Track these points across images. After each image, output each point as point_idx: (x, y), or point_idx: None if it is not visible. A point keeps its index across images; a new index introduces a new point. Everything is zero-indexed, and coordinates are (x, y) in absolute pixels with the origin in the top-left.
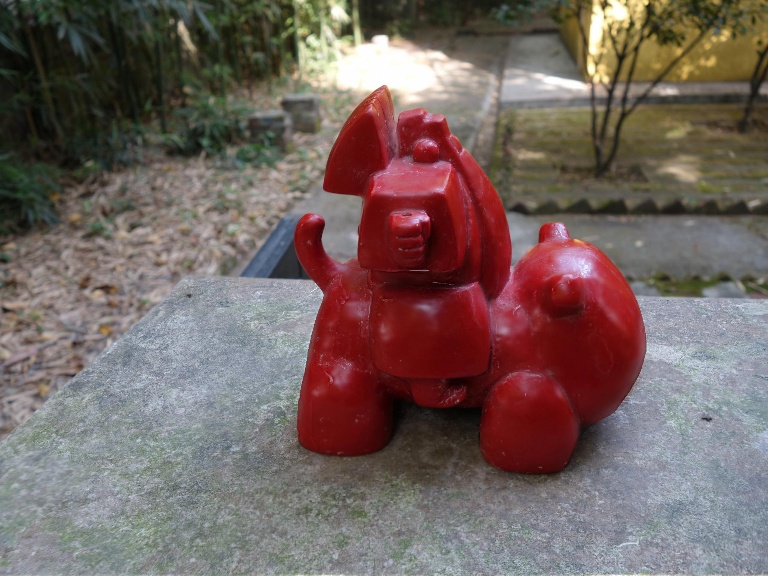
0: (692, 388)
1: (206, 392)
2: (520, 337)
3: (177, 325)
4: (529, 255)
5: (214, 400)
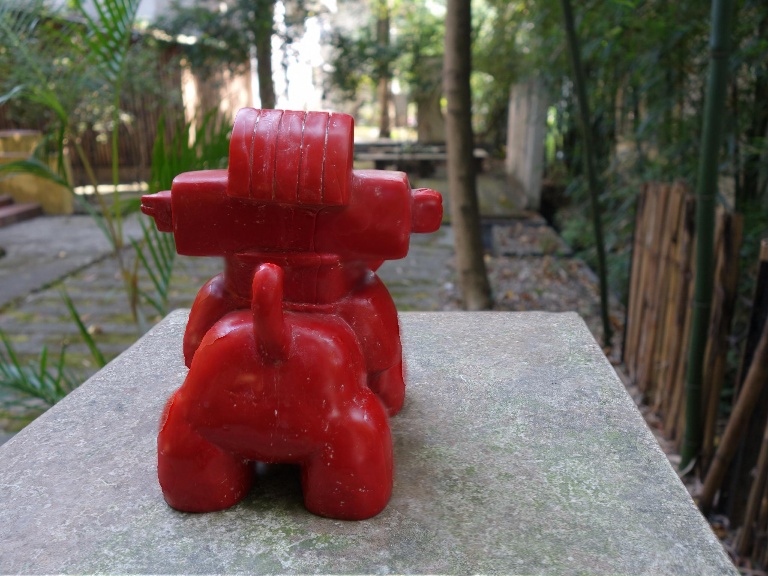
0: None
1: None
2: None
3: None
4: None
5: None
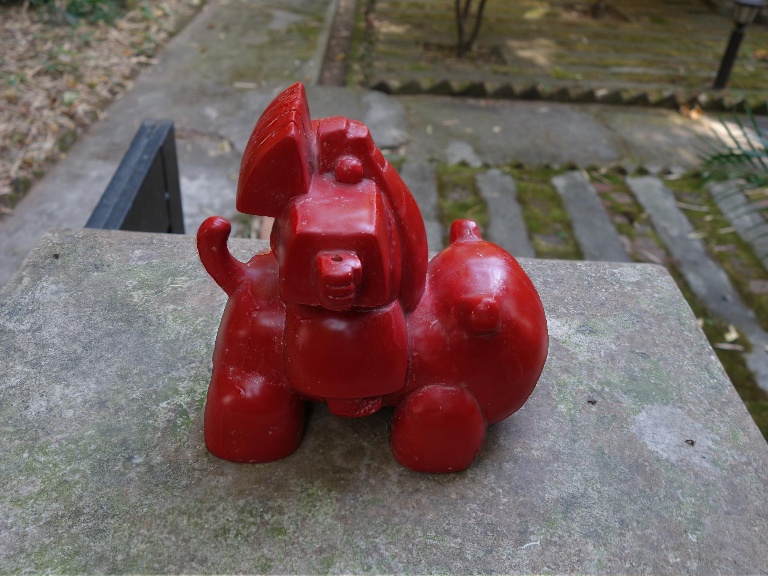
0: (578, 367)
1: (95, 387)
2: (437, 352)
3: (47, 297)
4: (444, 263)
5: (106, 398)
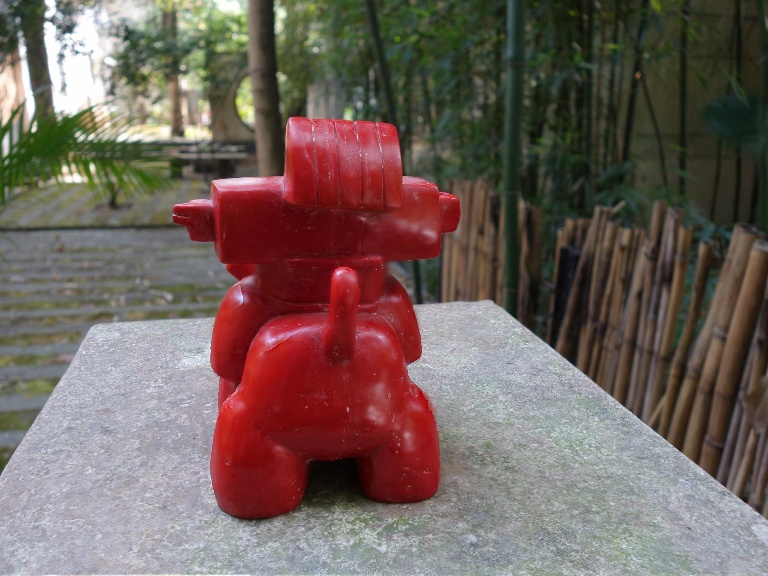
0: None
1: None
2: None
3: None
4: None
5: None
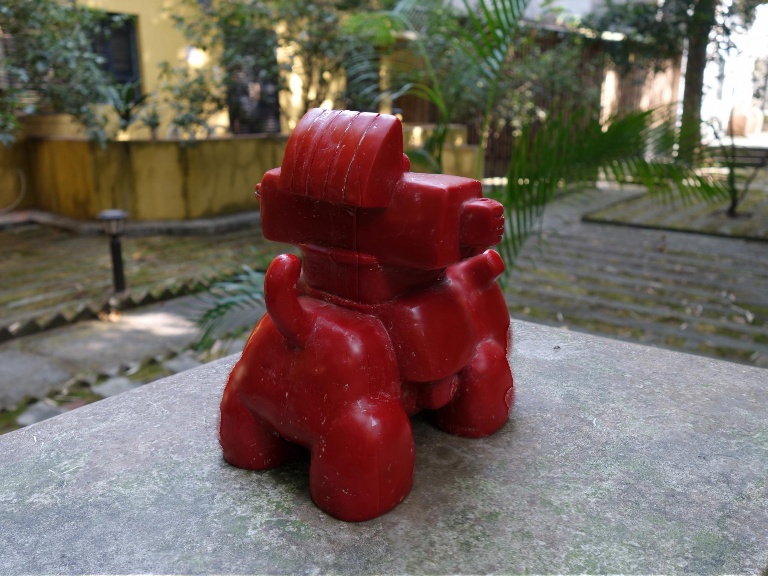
0: None
1: (153, 573)
2: (470, 314)
3: None
4: None
5: (184, 569)
